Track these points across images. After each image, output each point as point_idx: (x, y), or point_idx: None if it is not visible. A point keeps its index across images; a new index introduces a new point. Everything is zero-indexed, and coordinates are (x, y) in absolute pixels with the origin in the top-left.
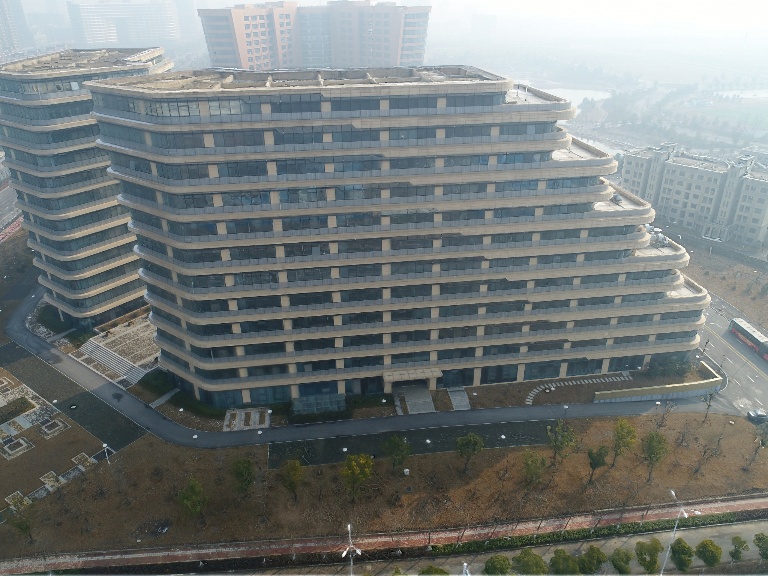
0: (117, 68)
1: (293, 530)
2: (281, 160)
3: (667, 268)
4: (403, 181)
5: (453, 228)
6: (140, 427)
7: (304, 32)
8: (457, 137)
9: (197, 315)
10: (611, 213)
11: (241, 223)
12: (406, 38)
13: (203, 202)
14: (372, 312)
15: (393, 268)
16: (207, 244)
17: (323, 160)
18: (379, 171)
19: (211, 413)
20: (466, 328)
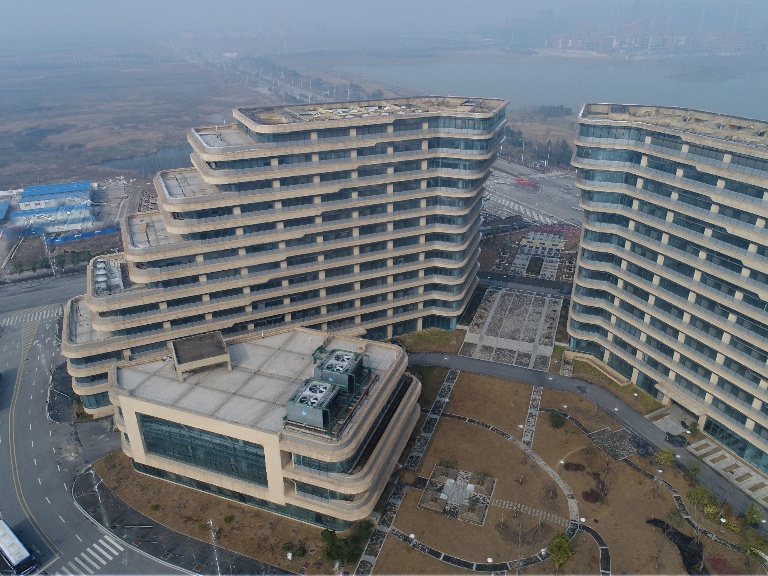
0: None
1: None
2: None
3: None
4: None
5: None
6: None
7: None
8: None
9: None
10: None
11: None
12: None
13: None
14: None
15: None
16: None
17: None
18: None
19: None
20: None
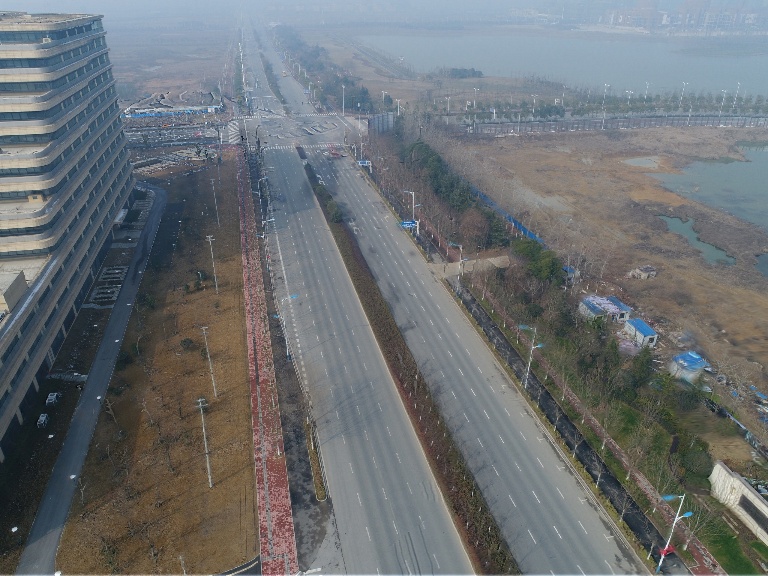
0: (4, 15)
1: None
2: None
3: None
4: None
5: None
6: None
7: None
8: None
9: None
10: None
11: None
12: None
13: None
14: None
15: None
16: None
17: None
18: None
19: None
20: None
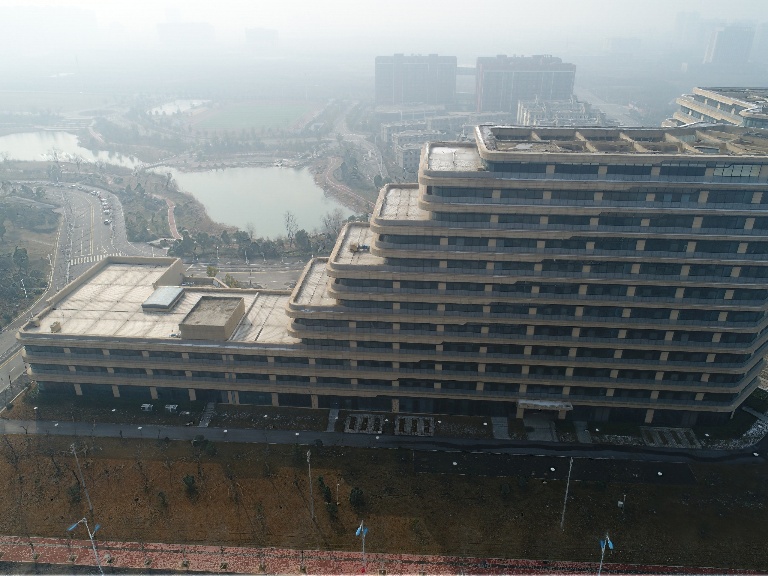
0: None
1: None
2: None
3: None
4: None
5: None
6: None
7: None
8: None
9: None
10: None
11: None
12: None
13: None
14: None
15: None
16: None
17: None
18: None
19: None
20: None
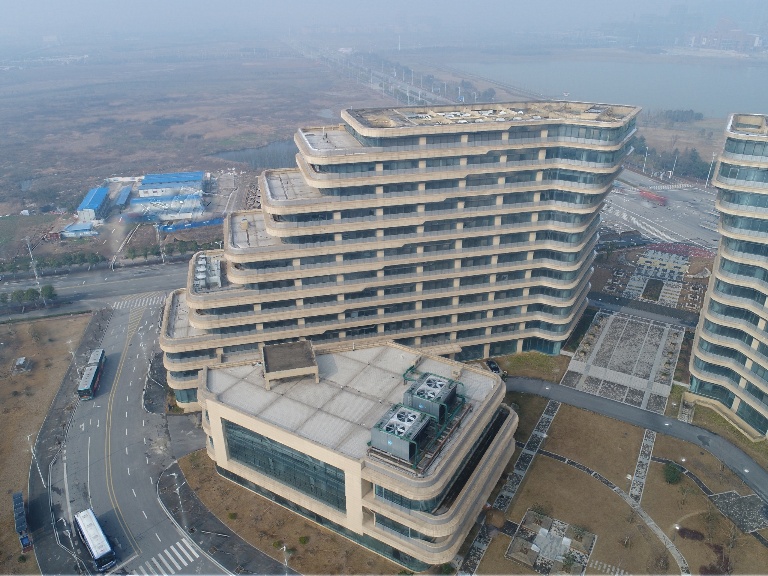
0: None
1: None
2: None
3: None
4: None
5: None
6: None
7: None
8: None
9: None
10: None
11: None
12: None
13: None
14: None
15: None
16: None
17: None
18: None
19: None
20: None
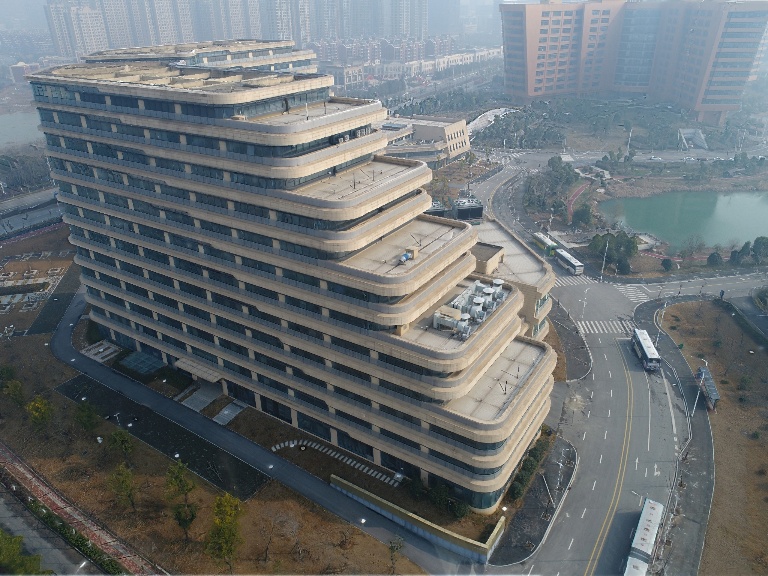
0: (154, 56)
1: (4, 434)
2: (93, 142)
3: (419, 364)
4: (161, 180)
5: (206, 237)
6: (56, 327)
7: (626, 30)
8: (195, 146)
9: (77, 255)
10: (346, 269)
11: (83, 189)
12: (726, 42)
13: (63, 166)
14: (167, 297)
15: (175, 261)
16: (66, 200)
17: (116, 147)
18: (149, 166)
19: (92, 336)
20: (237, 345)
